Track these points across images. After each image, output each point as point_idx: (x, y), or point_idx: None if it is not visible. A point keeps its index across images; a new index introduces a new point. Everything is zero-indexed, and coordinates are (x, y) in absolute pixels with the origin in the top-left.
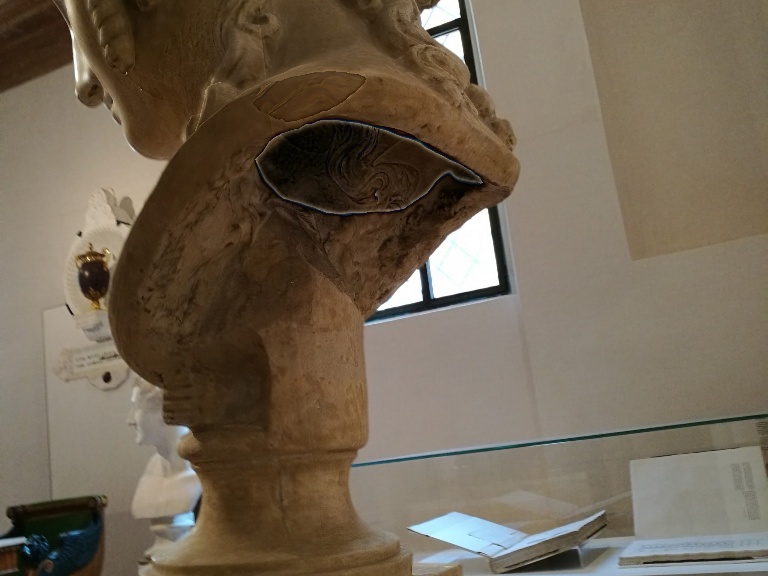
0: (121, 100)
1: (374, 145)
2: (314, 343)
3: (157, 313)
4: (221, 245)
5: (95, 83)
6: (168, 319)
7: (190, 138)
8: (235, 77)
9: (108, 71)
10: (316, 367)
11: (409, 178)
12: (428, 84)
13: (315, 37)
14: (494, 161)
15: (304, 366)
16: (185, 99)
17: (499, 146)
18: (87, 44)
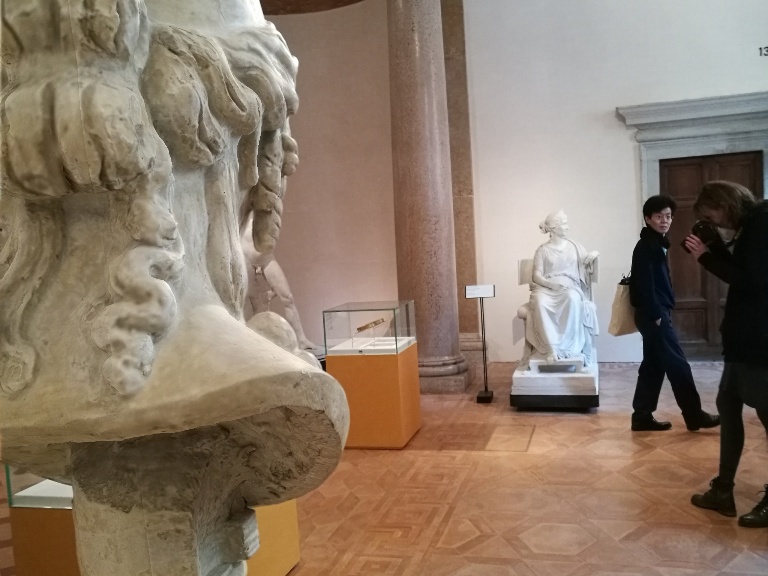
0: None
1: (233, 303)
2: None
3: (52, 478)
4: (44, 446)
5: None
6: (67, 479)
7: None
8: None
9: None
10: (83, 556)
11: (268, 339)
12: None
13: None
14: (51, 434)
15: (79, 552)
16: None
17: (34, 425)
18: None
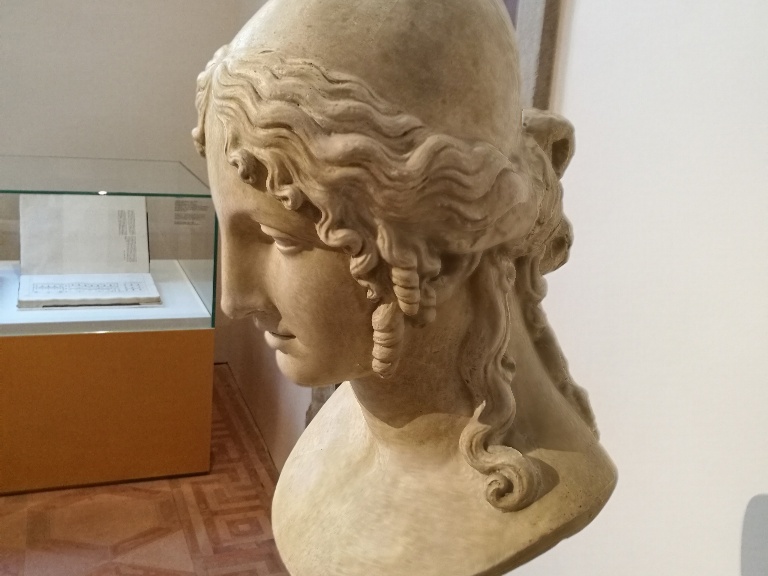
0: (328, 363)
1: None
2: None
3: None
4: None
5: (265, 311)
6: None
7: (546, 536)
8: (505, 428)
9: (335, 345)
10: None
11: None
12: None
13: (532, 379)
14: None
15: None
16: None
17: None
18: (327, 321)
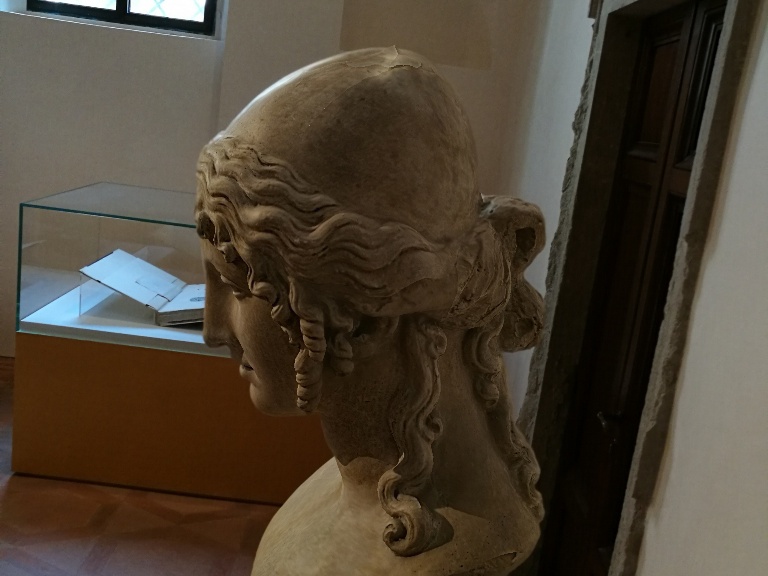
0: (274, 395)
1: None
2: None
3: None
4: None
5: (233, 344)
6: None
7: None
8: (417, 481)
9: (275, 380)
10: None
11: None
12: (531, 510)
13: (464, 444)
14: None
15: None
16: (332, 414)
17: None
18: (264, 358)
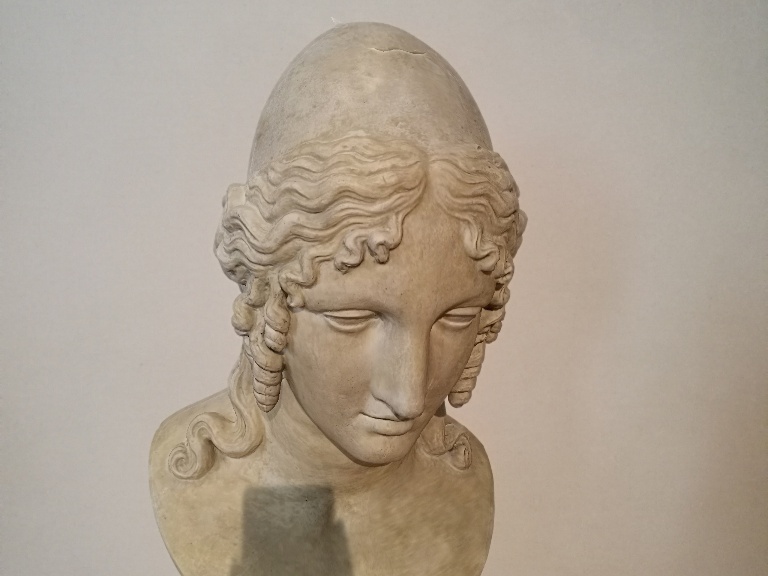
0: None
1: None
2: None
3: None
4: None
5: None
6: None
7: None
8: None
9: None
10: None
11: None
12: None
13: None
14: None
15: None
16: None
17: None
18: None
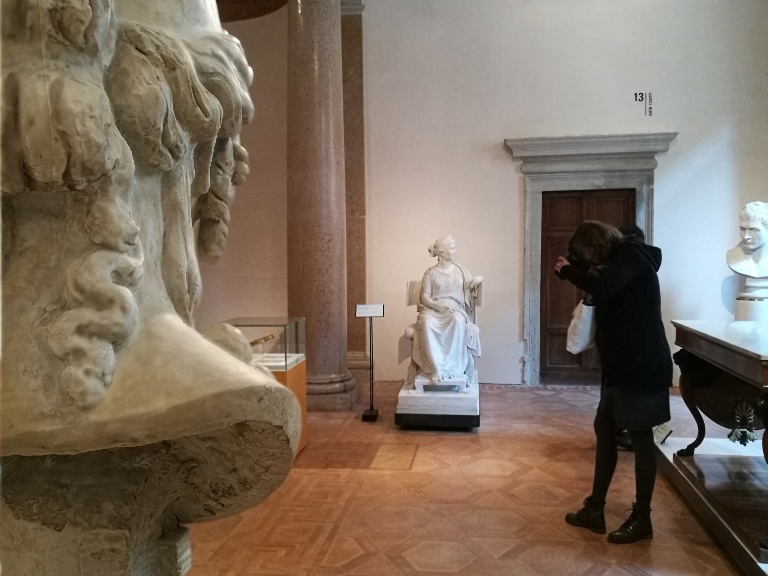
0: None
1: (187, 313)
2: (2, 557)
3: None
4: None
5: None
6: None
7: None
8: None
9: None
10: None
11: None
12: None
13: None
14: None
15: None
16: None
17: None
18: None
